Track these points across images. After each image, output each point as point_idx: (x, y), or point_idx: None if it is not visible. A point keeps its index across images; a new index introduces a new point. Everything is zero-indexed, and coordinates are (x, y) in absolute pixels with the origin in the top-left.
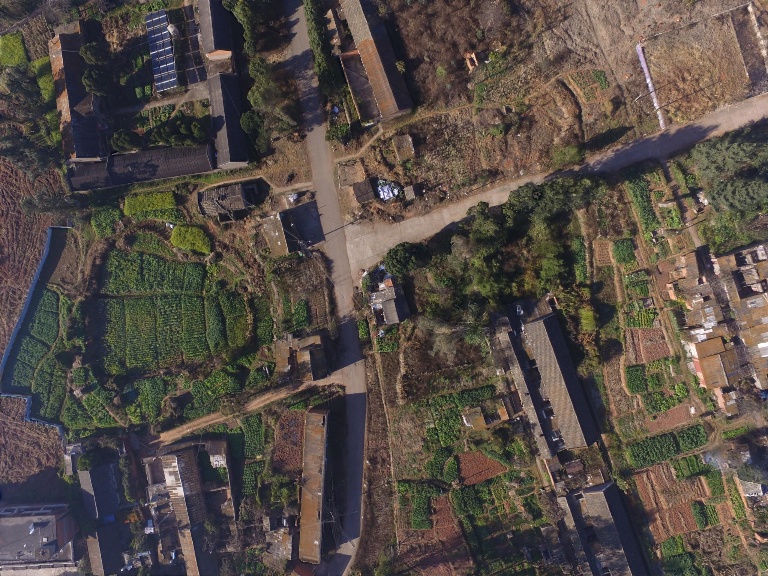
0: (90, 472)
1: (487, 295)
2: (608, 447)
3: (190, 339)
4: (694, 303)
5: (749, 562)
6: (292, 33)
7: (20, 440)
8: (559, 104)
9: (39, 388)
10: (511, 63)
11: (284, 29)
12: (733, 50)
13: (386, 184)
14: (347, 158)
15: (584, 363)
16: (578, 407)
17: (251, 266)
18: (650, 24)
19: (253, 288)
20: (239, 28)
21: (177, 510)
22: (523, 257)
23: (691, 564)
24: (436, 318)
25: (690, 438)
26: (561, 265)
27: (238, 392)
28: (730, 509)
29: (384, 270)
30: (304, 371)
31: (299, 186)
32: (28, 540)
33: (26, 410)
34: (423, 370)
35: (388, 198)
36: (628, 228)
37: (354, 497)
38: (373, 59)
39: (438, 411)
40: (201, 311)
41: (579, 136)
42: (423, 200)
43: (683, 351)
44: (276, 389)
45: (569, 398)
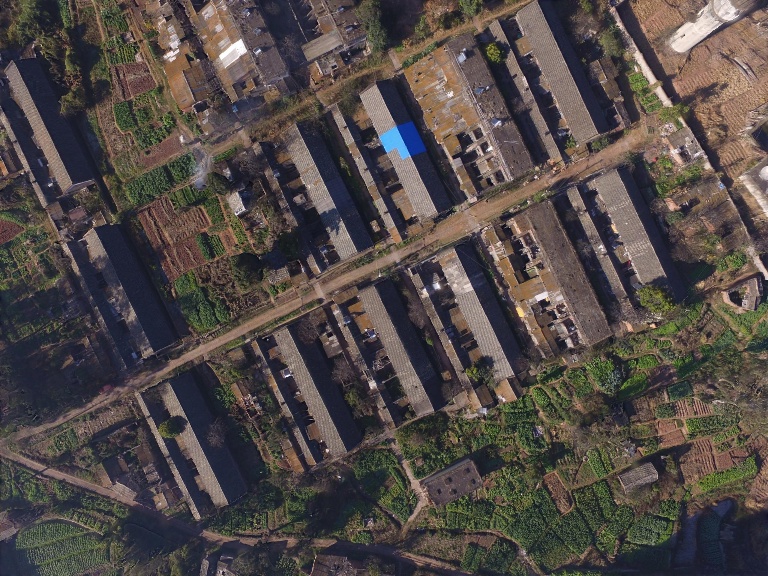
0: None
1: None
2: (109, 189)
3: None
4: (159, 25)
5: (260, 289)
6: None
7: None
8: None
9: None
10: None
11: None
12: None
13: None
14: None
15: (60, 100)
16: (63, 146)
17: None
18: None
19: None
20: None
21: None
22: None
23: (204, 298)
24: None
25: (180, 166)
26: (35, 7)
27: None
28: (232, 236)
29: None
30: None
31: None
32: None
33: None
34: None
35: None
36: None
37: None
38: None
39: None
40: None
41: None
42: None
43: (166, 81)
44: None
45: (49, 137)
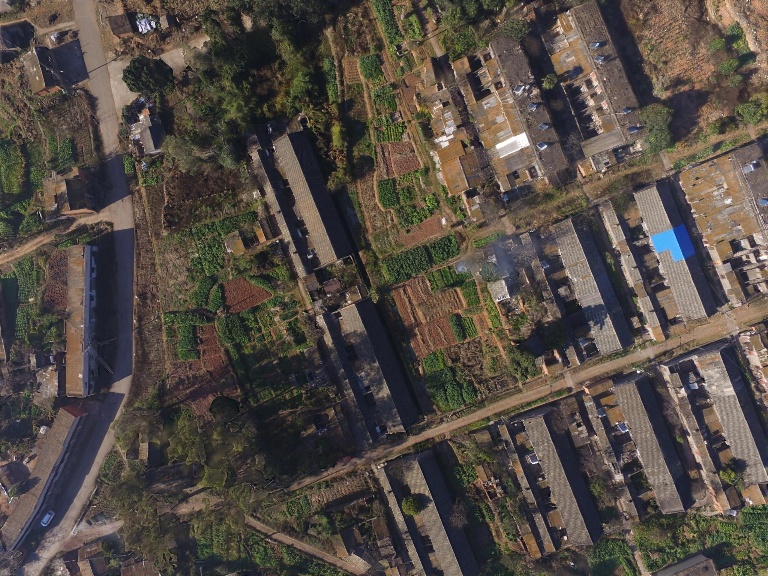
0: None
1: (237, 115)
2: (365, 264)
3: None
4: (435, 110)
5: (509, 373)
6: None
7: None
8: None
9: None
10: None
11: None
12: None
13: (144, 18)
14: None
15: (330, 175)
16: (328, 221)
17: (22, 111)
18: None
19: (25, 133)
20: None
21: None
22: (277, 81)
23: (452, 378)
24: None
25: (441, 248)
26: (308, 82)
27: (12, 237)
28: (486, 319)
29: (144, 102)
30: (62, 202)
31: (62, 26)
32: None
33: None
34: (183, 198)
35: (146, 31)
36: (373, 43)
37: (125, 334)
38: None
39: (201, 240)
40: None
41: None
42: (180, 31)
43: (432, 162)
44: (48, 231)
45: (317, 211)
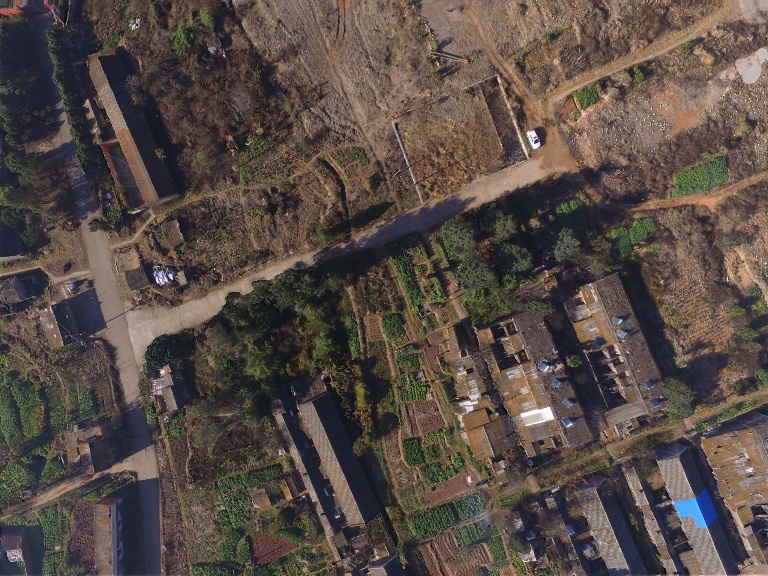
0: None
1: (260, 378)
2: (392, 520)
3: None
4: (459, 376)
5: None
6: (60, 121)
7: None
8: (322, 182)
9: None
10: (271, 144)
11: (50, 118)
12: (486, 121)
13: (161, 269)
14: (123, 244)
15: (356, 441)
16: (355, 484)
17: (39, 356)
18: (403, 99)
19: (43, 378)
20: (3, 119)
21: None
22: (299, 336)
23: None
24: (218, 401)
25: (467, 507)
26: (330, 344)
27: (34, 483)
28: (513, 573)
29: None
30: (86, 464)
31: (77, 275)
32: None
33: None
34: None
35: (164, 283)
36: (395, 303)
37: None
38: (131, 148)
39: (227, 493)
40: None
41: (343, 214)
42: (198, 283)
43: (456, 422)
44: (71, 479)
45: (344, 477)
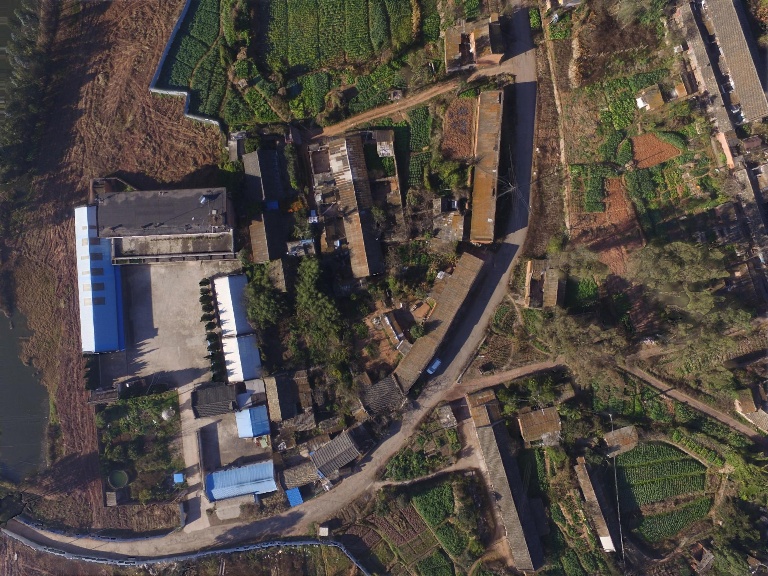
0: (258, 153)
1: None
2: None
3: (353, 39)
4: None
5: None
6: None
7: (176, 139)
8: None
9: (199, 85)
10: None
11: None
12: None
13: None
14: None
15: (767, 30)
16: (760, 75)
17: None
18: None
19: None
20: None
21: (343, 196)
22: None
23: None
24: (612, 1)
25: None
26: None
27: (403, 87)
28: None
29: None
30: (482, 46)
31: None
32: (197, 213)
33: (183, 110)
34: (599, 50)
35: None
36: None
37: None
38: None
39: (612, 94)
40: (365, 12)
41: None
42: None
43: None
44: (443, 82)
45: (753, 64)
